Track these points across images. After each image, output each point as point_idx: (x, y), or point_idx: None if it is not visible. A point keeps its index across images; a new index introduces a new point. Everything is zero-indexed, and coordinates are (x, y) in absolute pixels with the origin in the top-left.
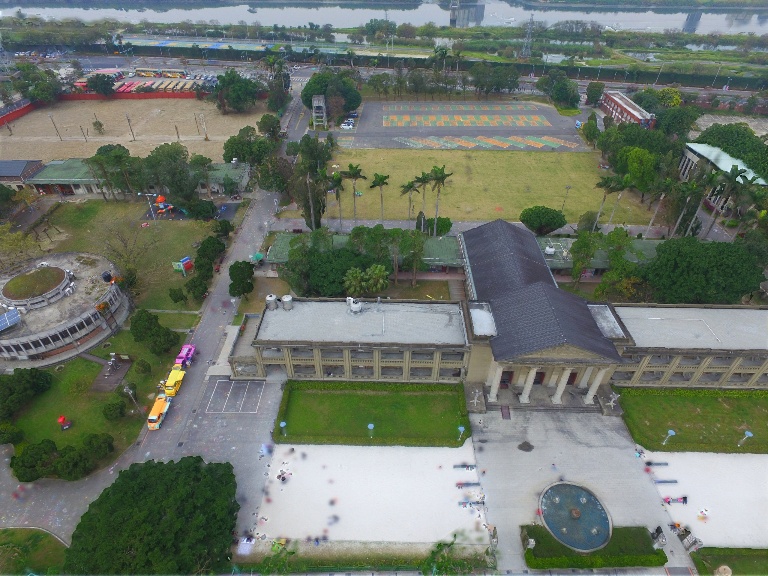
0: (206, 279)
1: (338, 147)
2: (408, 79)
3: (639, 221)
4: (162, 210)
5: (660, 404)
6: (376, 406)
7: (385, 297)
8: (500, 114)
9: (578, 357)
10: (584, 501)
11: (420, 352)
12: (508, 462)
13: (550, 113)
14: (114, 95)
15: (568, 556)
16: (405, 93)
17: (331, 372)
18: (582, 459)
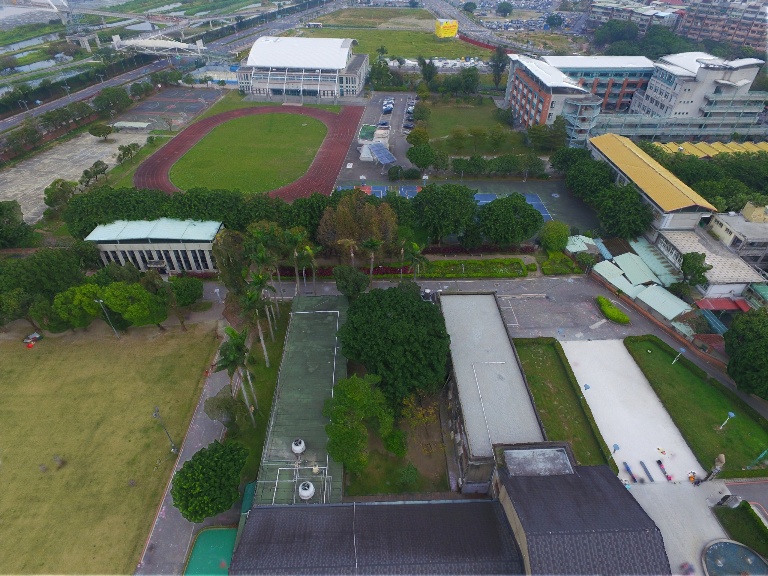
0: None
1: None
2: None
3: (208, 348)
4: None
5: None
6: None
7: None
8: None
9: None
10: (721, 563)
11: None
12: None
13: None
14: None
15: None
16: None
17: None
18: None
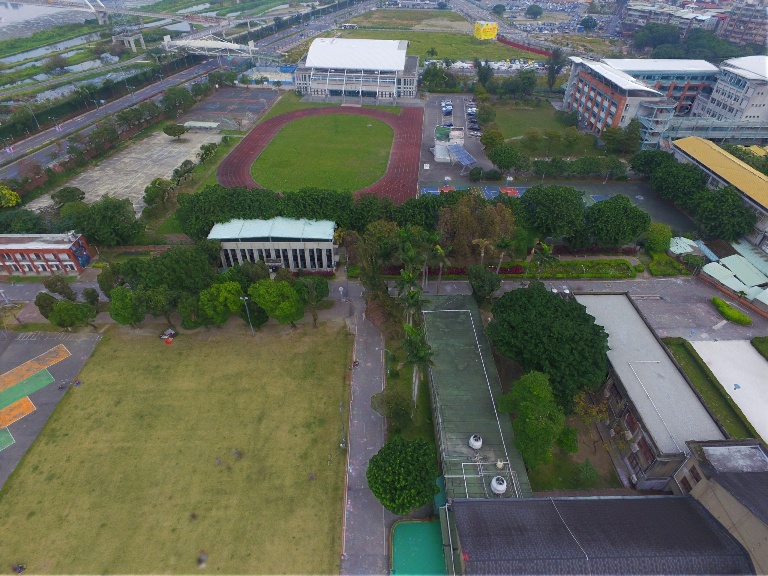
0: None
1: None
2: None
3: (344, 346)
4: None
5: None
6: None
7: None
8: None
9: None
10: None
11: None
12: None
13: None
14: None
15: None
16: None
17: None
18: None
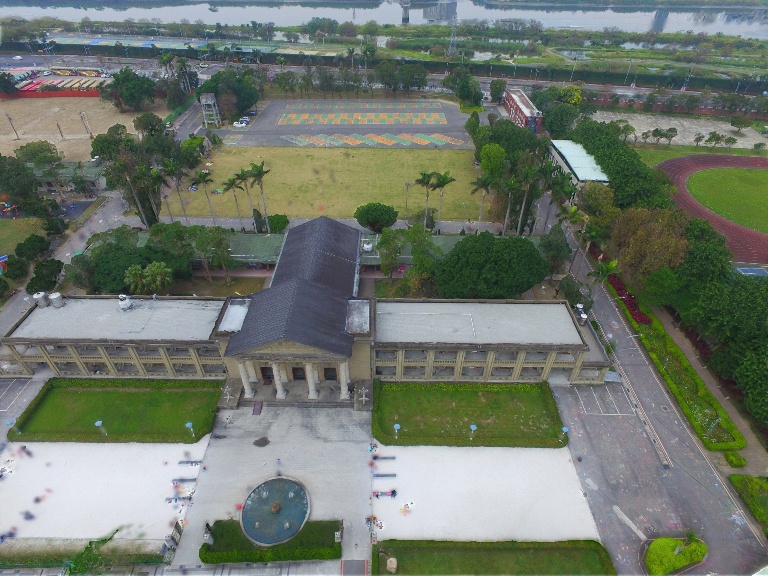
0: (13, 277)
1: (221, 145)
2: (313, 77)
3: (487, 217)
4: (7, 209)
5: (418, 399)
6: (131, 403)
7: (192, 294)
8: (401, 112)
9: (309, 352)
10: (291, 495)
11: (185, 349)
12: (236, 457)
13: (452, 111)
14: (17, 94)
15: (240, 550)
16: (312, 91)
17: (97, 369)
18: (312, 454)
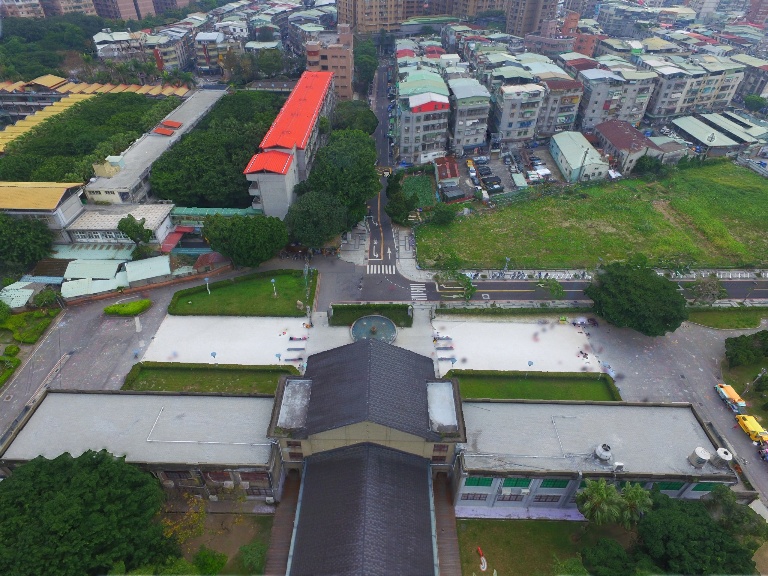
0: None
1: None
2: None
3: None
4: None
5: None
6: None
7: None
8: None
9: None
10: (364, 337)
11: None
12: None
13: None
14: None
15: (389, 307)
16: None
17: None
18: None
